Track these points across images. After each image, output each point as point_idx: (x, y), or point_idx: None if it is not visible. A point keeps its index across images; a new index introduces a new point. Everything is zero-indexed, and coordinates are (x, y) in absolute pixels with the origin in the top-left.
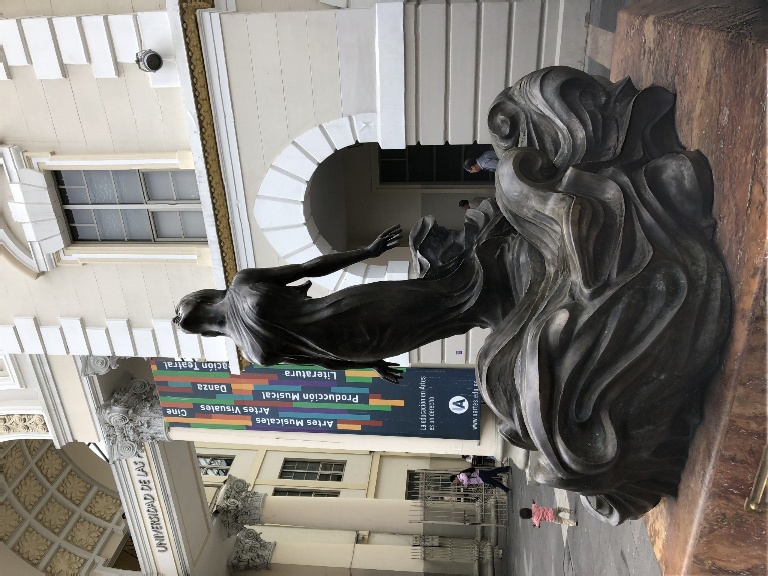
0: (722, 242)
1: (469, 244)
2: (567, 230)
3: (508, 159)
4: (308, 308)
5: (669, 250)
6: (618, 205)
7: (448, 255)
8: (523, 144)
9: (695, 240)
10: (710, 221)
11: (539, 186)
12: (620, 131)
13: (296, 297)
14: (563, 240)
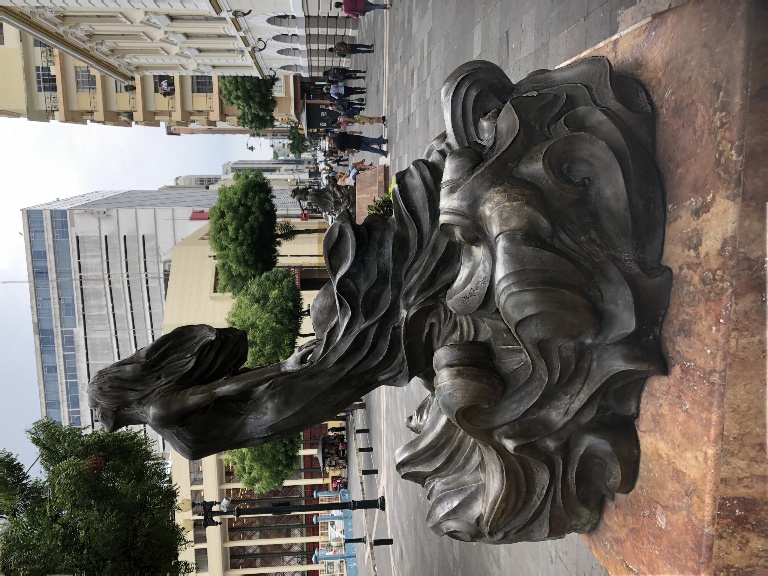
0: (607, 512)
1: (396, 289)
2: (487, 522)
3: (452, 404)
4: (240, 438)
5: (563, 520)
6: (541, 486)
7: (371, 295)
8: (480, 292)
9: (588, 510)
10: (610, 496)
11: (478, 432)
12: (586, 386)
13: (224, 425)
14: (485, 477)
